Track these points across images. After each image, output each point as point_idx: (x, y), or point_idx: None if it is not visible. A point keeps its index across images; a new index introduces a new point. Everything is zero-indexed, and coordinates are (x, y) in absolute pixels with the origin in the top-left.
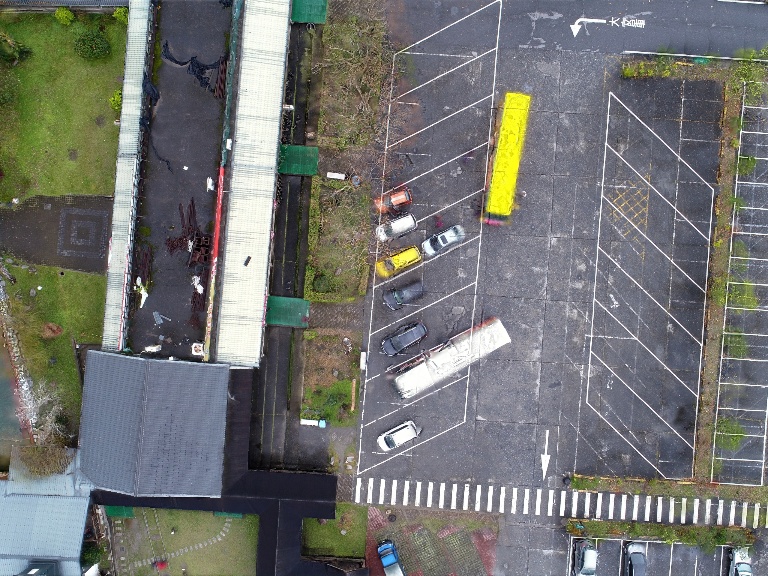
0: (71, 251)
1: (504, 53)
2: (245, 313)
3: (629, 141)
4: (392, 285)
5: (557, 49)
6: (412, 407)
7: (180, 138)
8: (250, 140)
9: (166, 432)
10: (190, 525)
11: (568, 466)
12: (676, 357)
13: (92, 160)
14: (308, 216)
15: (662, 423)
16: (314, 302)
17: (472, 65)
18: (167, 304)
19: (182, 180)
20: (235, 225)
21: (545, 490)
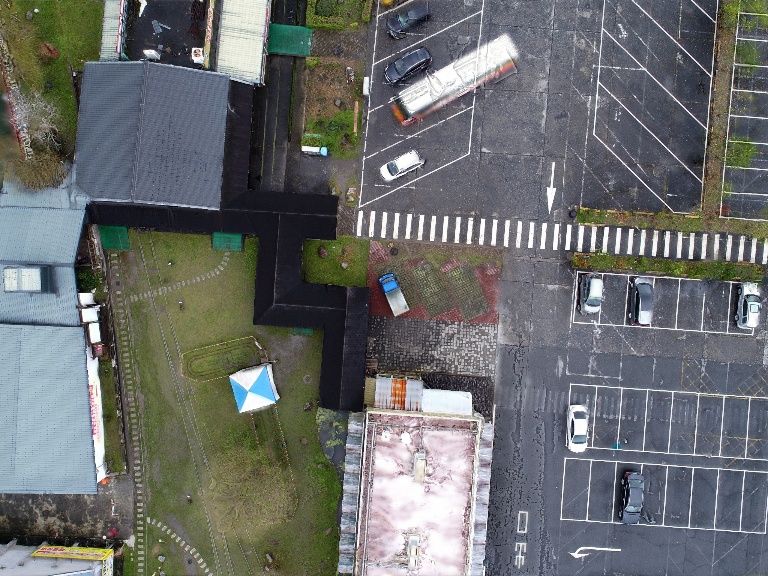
0: None
1: None
2: (246, 26)
3: None
4: (396, 14)
5: None
6: (415, 139)
7: None
8: None
9: (164, 138)
10: (188, 258)
11: (574, 199)
12: (685, 88)
13: None
14: None
15: (670, 156)
16: (316, 30)
17: None
18: (166, 13)
19: None
20: None
21: (550, 224)
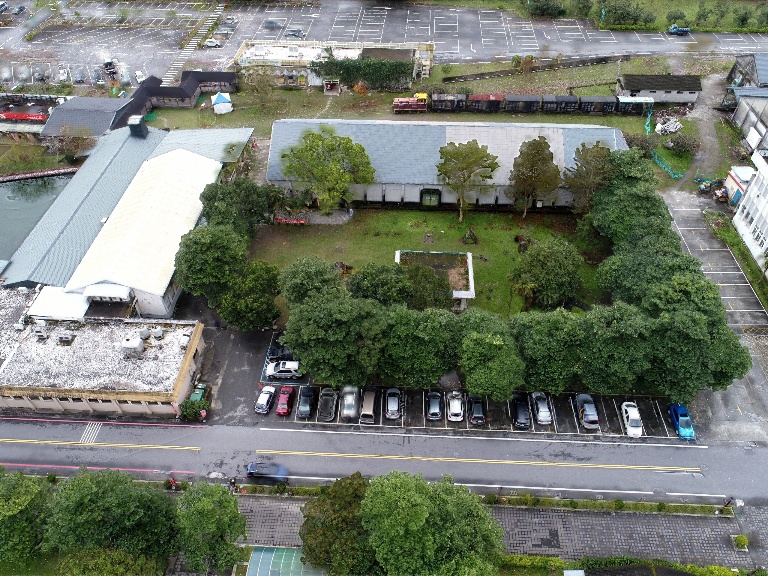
0: None
1: None
2: None
3: (55, 39)
4: (74, 81)
5: (6, 51)
6: (131, 77)
7: None
8: None
9: None
10: None
11: None
12: None
13: None
14: None
15: None
16: None
17: None
18: None
19: None
20: None
21: (182, 52)
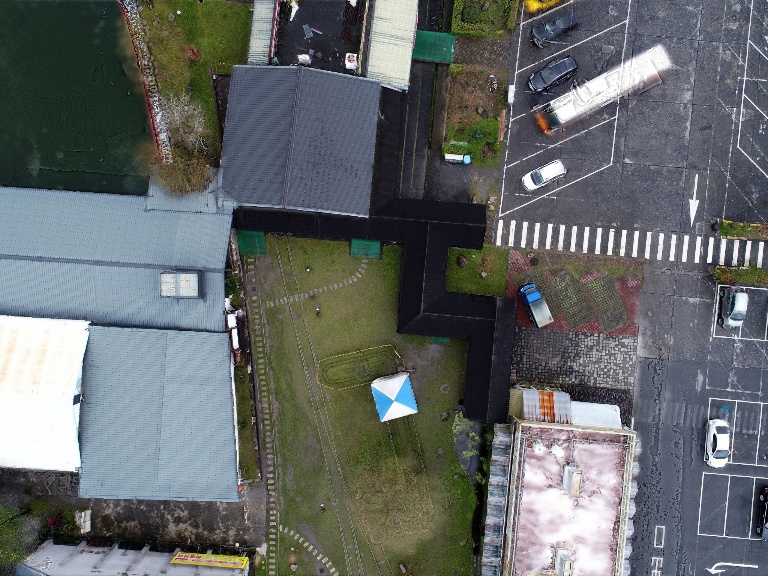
0: None
1: None
2: (396, 32)
3: None
4: (540, 22)
5: None
6: (557, 148)
7: None
8: None
9: (316, 144)
10: (325, 265)
11: (717, 212)
12: None
13: None
14: None
15: None
16: (460, 37)
17: None
18: (318, 17)
19: None
20: None
21: (692, 236)
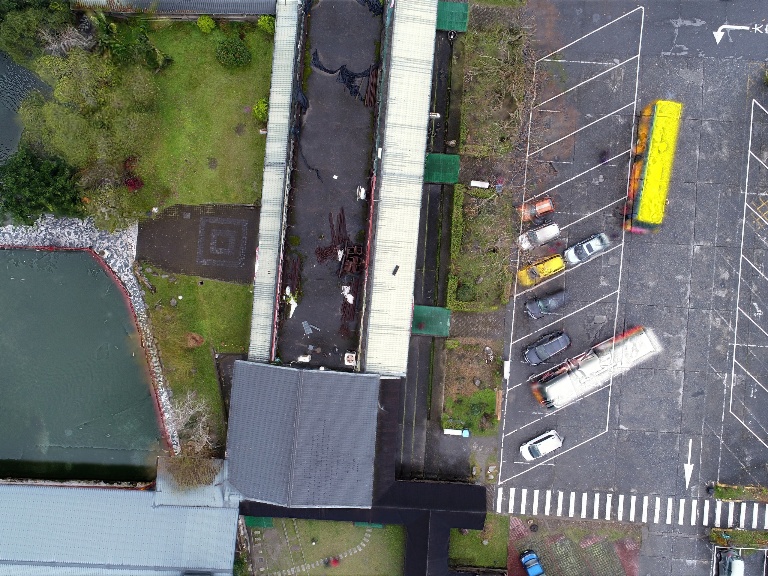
0: (210, 260)
1: (646, 60)
2: (393, 323)
3: None
4: (533, 294)
5: (700, 56)
6: (554, 416)
7: (330, 147)
8: (398, 149)
9: (318, 443)
10: (330, 535)
11: (711, 475)
12: None
13: (232, 169)
14: (449, 224)
15: None
16: (455, 311)
17: (614, 72)
18: (317, 314)
19: (332, 189)
20: (384, 234)
21: (688, 500)
